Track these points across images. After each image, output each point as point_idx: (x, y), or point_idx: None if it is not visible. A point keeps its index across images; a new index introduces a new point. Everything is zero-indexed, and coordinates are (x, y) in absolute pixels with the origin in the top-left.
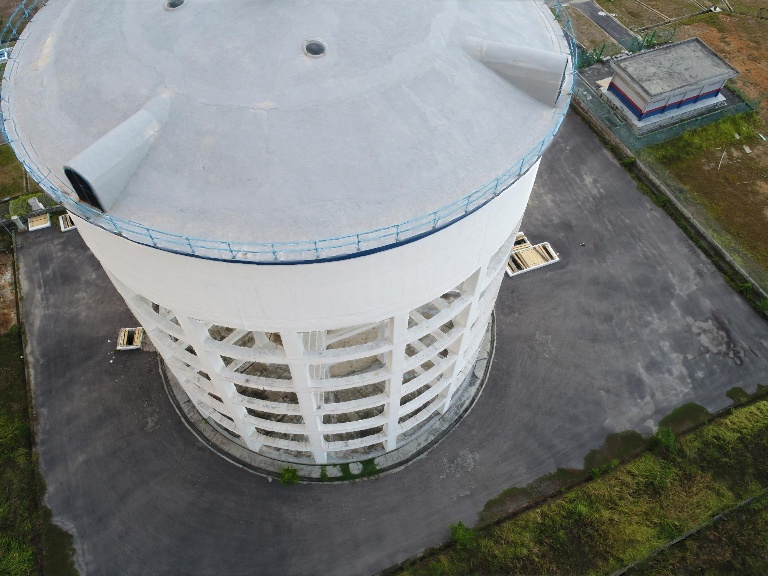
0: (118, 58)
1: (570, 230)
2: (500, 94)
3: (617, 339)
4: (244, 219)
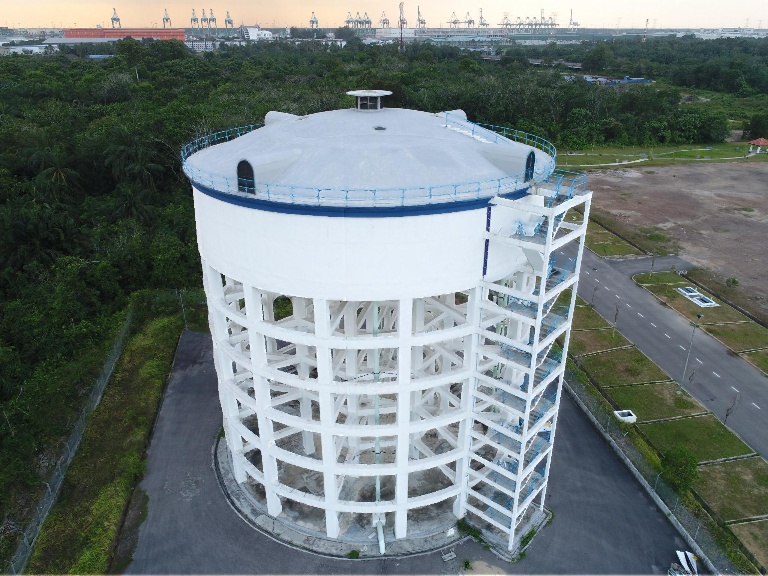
0: None
1: None
2: None
3: None
4: None
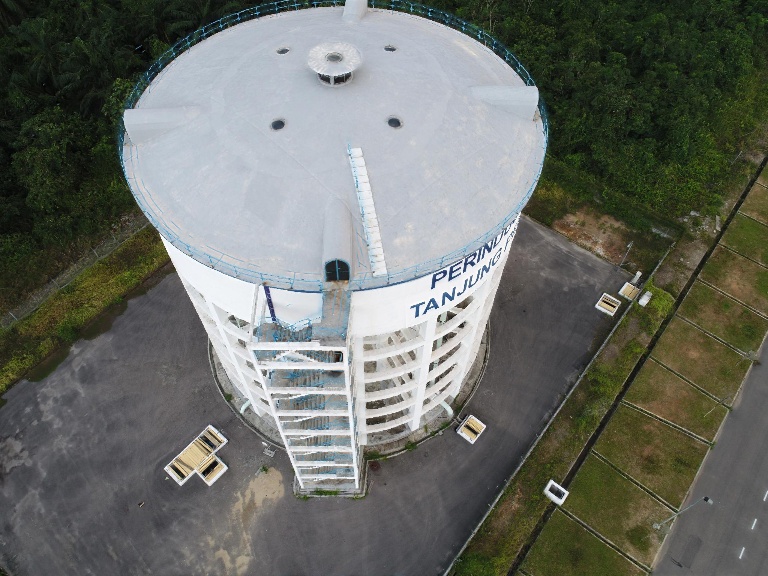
0: (397, 30)
1: (157, 519)
2: (170, 106)
3: (103, 410)
4: (280, 19)
